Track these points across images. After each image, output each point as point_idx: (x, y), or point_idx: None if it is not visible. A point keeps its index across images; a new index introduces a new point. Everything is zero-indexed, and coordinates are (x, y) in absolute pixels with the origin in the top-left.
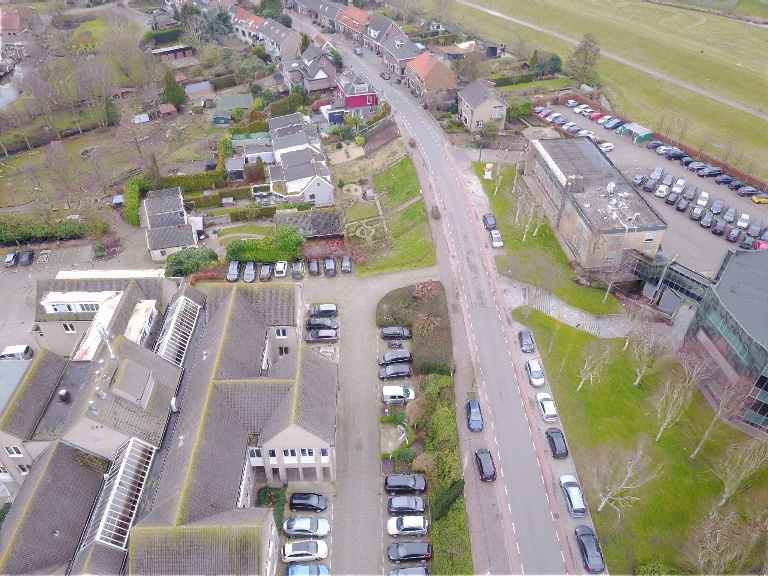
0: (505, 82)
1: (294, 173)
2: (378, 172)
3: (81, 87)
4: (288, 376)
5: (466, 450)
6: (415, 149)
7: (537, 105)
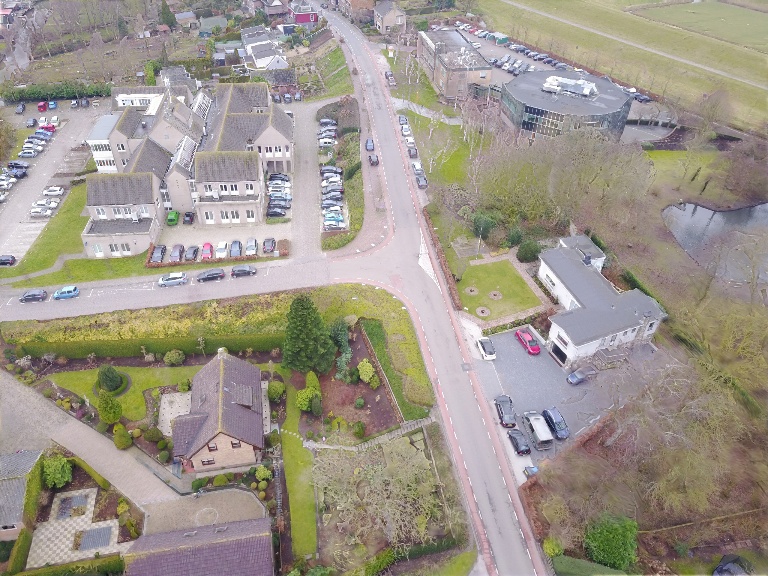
0: (413, 12)
1: (261, 55)
2: (319, 59)
3: (101, 8)
4: None
5: (364, 157)
6: (344, 44)
7: (433, 24)
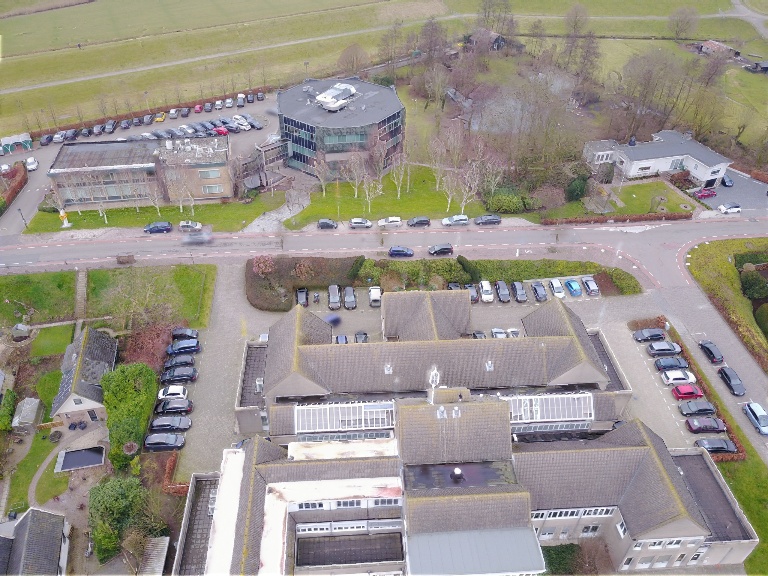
0: None
1: None
2: None
3: None
4: (416, 305)
5: None
6: None
7: None
